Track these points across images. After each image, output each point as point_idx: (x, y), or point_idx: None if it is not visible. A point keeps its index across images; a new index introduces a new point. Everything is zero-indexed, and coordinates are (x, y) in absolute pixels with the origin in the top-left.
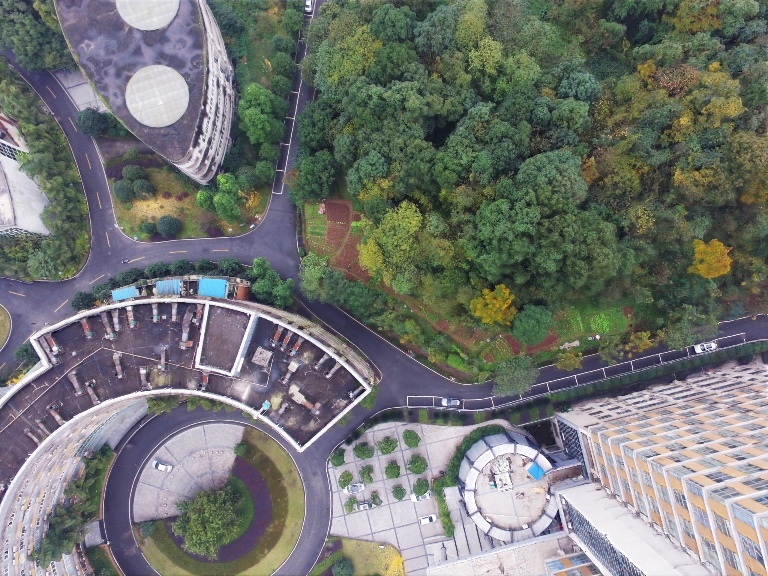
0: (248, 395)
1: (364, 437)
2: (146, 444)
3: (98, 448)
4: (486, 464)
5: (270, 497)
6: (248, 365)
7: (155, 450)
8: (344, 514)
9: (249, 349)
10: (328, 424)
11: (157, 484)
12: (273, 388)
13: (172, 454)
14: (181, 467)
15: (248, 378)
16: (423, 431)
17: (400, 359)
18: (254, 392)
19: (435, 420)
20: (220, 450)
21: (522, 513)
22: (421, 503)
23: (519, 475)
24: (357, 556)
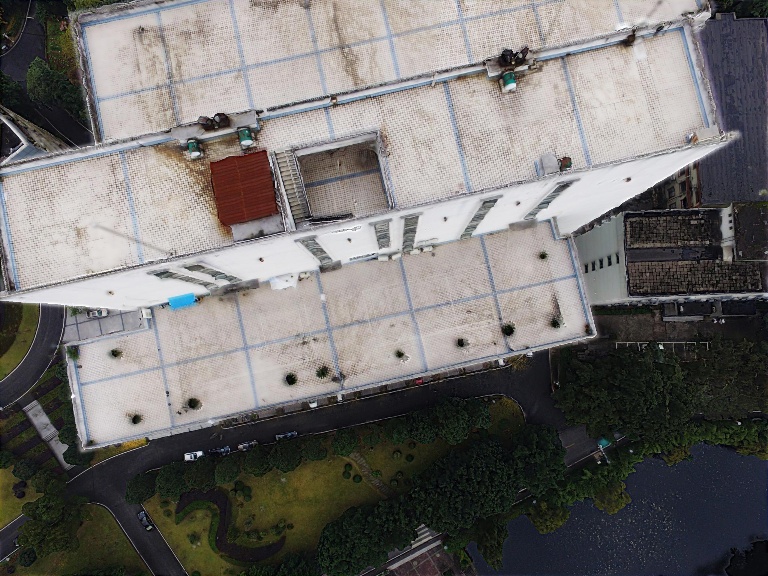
0: None
1: None
2: None
3: None
4: None
5: (4, 303)
6: None
7: None
8: (77, 322)
9: None
10: None
11: None
12: None
13: None
14: None
15: None
16: None
17: None
18: None
19: None
20: None
21: None
22: None
23: None
24: None
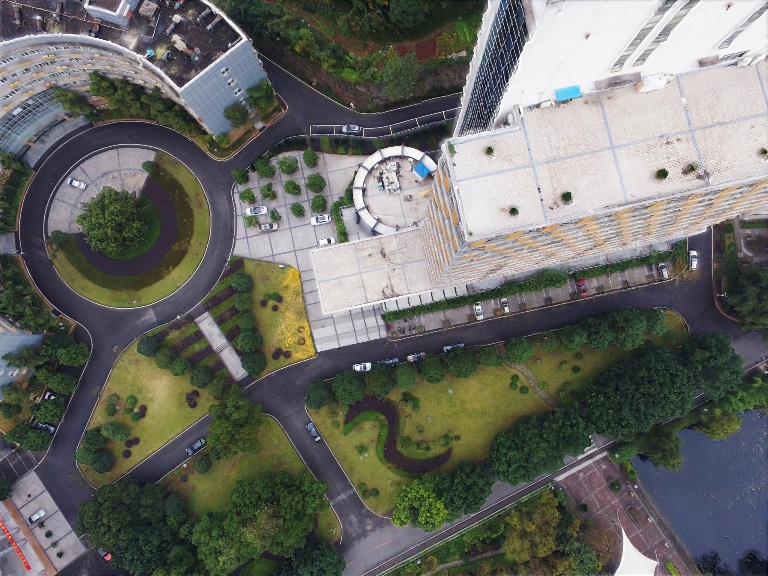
0: (135, 46)
1: (269, 164)
2: (63, 165)
3: (14, 153)
4: (374, 164)
5: (177, 217)
6: (137, 20)
7: (71, 170)
8: (247, 236)
9: (138, 6)
10: (206, 68)
11: (71, 201)
12: (158, 40)
13: (87, 174)
14: (94, 186)
15: (136, 31)
16: (325, 160)
17: (305, 92)
18: (141, 43)
19: (336, 148)
20: (132, 172)
21: (409, 215)
22: (321, 228)
23: (407, 179)
24: (258, 276)
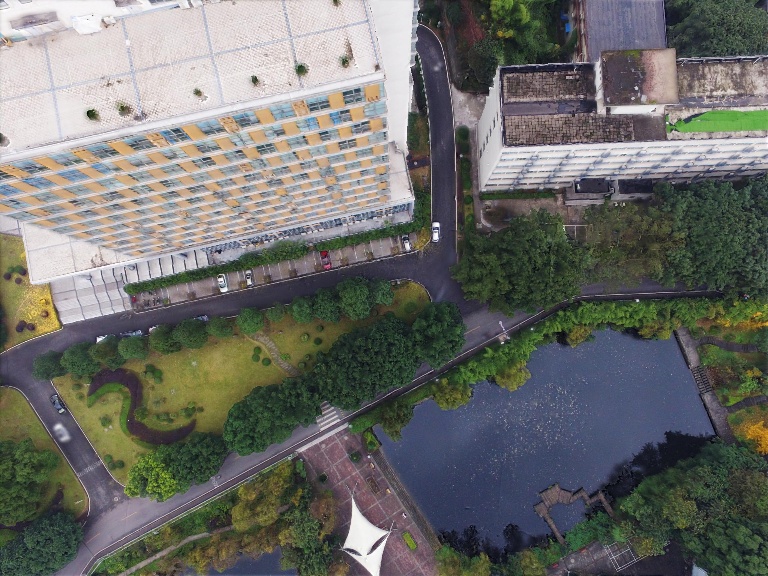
0: None
1: None
2: None
3: None
4: None
5: None
6: None
7: None
8: None
9: None
10: None
11: None
12: None
13: None
14: None
15: None
16: None
17: None
18: None
19: None
20: None
21: None
22: None
23: None
24: (2, 249)
